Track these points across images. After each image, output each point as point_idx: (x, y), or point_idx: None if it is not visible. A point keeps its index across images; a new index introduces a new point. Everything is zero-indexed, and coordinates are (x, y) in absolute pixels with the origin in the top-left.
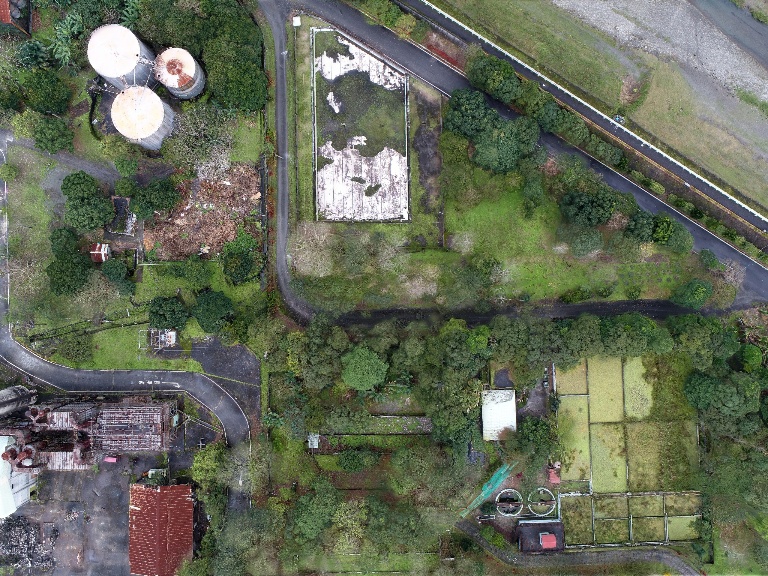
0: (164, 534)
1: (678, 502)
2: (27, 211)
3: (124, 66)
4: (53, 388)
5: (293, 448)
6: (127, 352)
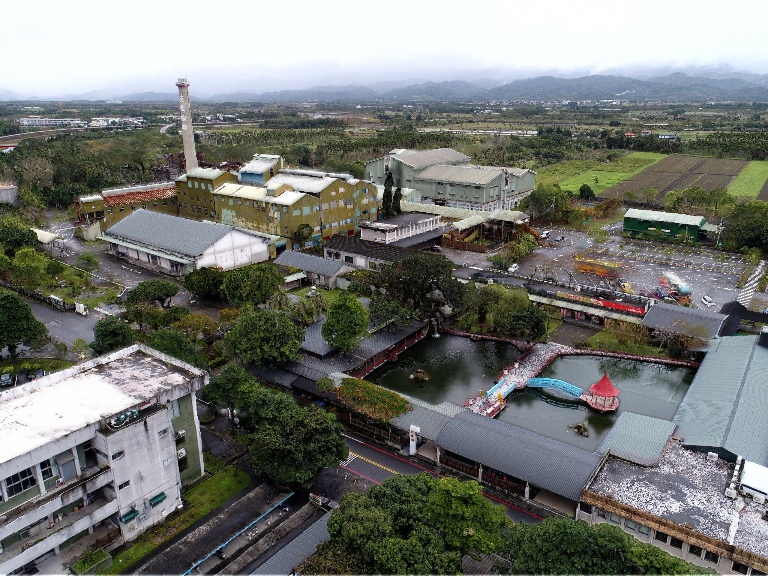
0: None
1: None
2: None
3: None
4: None
5: None
6: None
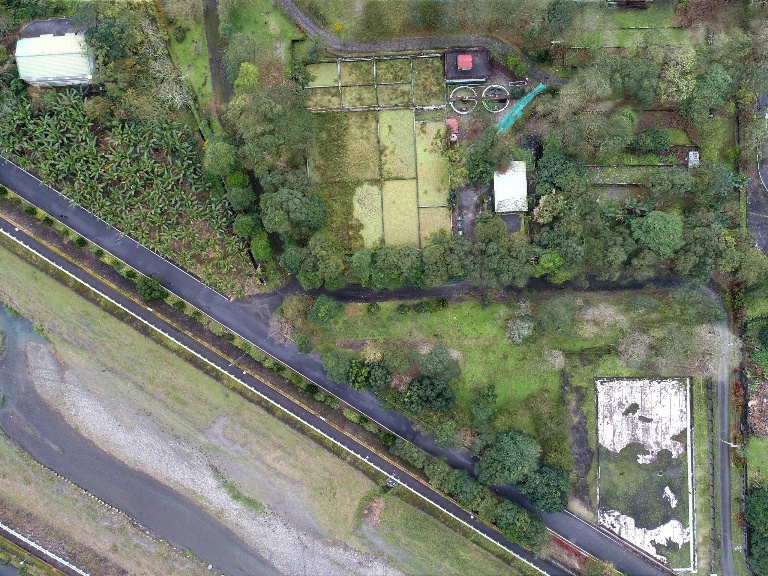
0: None
1: (327, 101)
2: None
3: None
4: None
5: (712, 151)
6: None
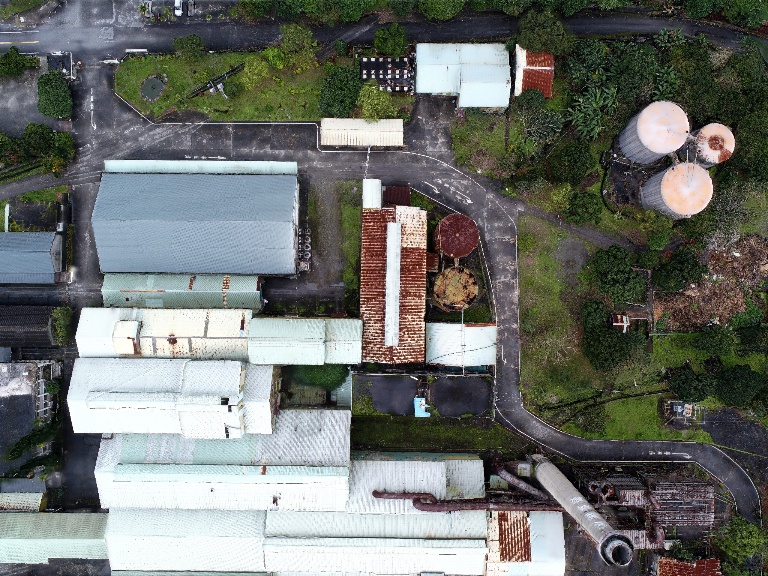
0: None
1: None
2: (538, 281)
3: (674, 142)
4: (564, 458)
5: None
6: (637, 422)
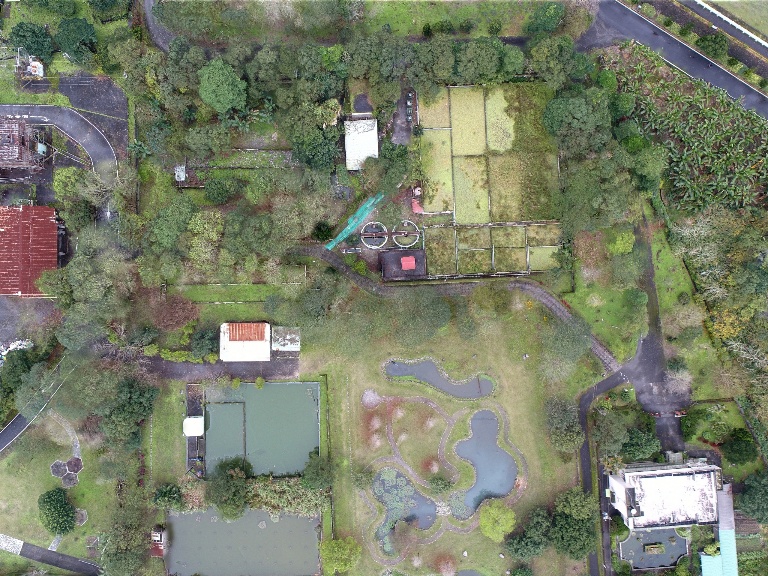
0: (27, 252)
1: (540, 233)
2: None
3: None
4: None
5: (161, 183)
6: None
